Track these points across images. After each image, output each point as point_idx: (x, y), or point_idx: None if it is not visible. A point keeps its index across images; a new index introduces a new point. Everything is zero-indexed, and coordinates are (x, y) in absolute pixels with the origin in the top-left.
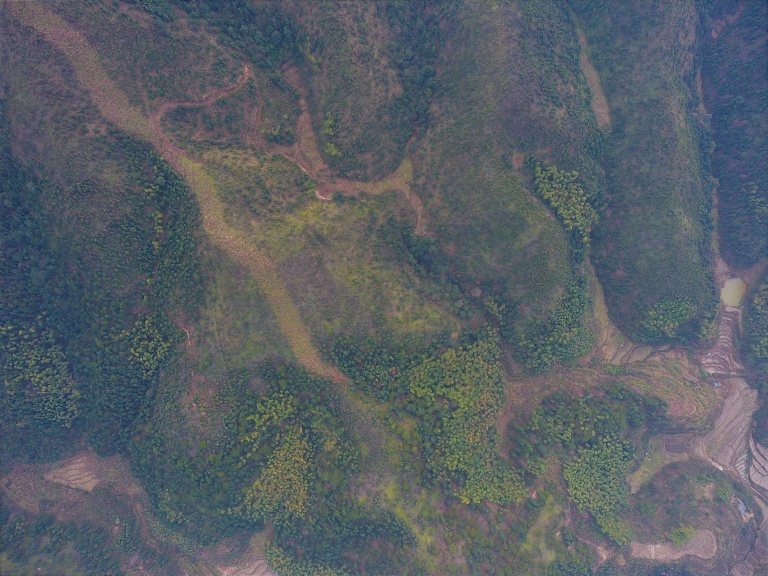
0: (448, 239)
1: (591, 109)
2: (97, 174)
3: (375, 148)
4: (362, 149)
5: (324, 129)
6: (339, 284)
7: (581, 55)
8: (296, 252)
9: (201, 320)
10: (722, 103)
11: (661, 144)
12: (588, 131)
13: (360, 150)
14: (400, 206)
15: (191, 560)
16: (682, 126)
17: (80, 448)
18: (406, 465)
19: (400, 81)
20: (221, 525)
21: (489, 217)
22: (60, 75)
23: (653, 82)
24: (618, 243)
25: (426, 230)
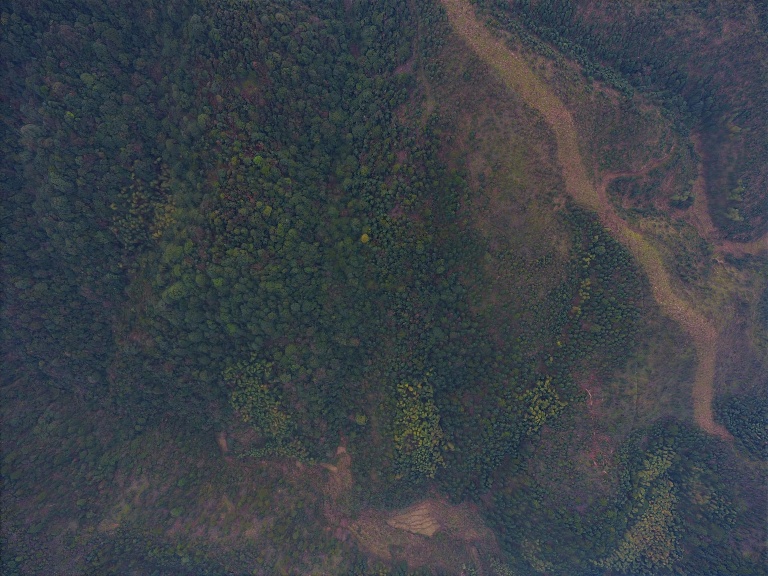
0: None
1: None
2: (556, 246)
3: (766, 212)
4: (759, 214)
5: (732, 195)
6: (751, 349)
7: None
8: (729, 320)
9: (613, 382)
10: None
11: None
12: None
13: (757, 214)
14: None
15: None
16: None
17: (429, 496)
18: None
19: None
20: (581, 574)
21: None
22: (548, 154)
23: None
24: None
25: None
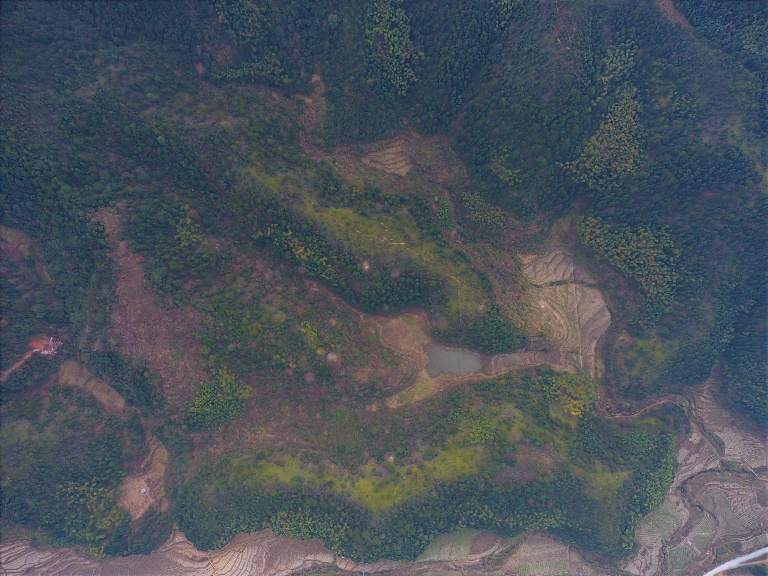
0: None
1: None
2: None
3: None
4: None
5: None
6: None
7: None
8: None
9: None
10: None
11: None
12: None
13: None
14: None
15: (497, 244)
16: None
17: (402, 127)
18: (753, 103)
19: None
20: (549, 188)
21: None
22: None
23: None
24: None
25: None
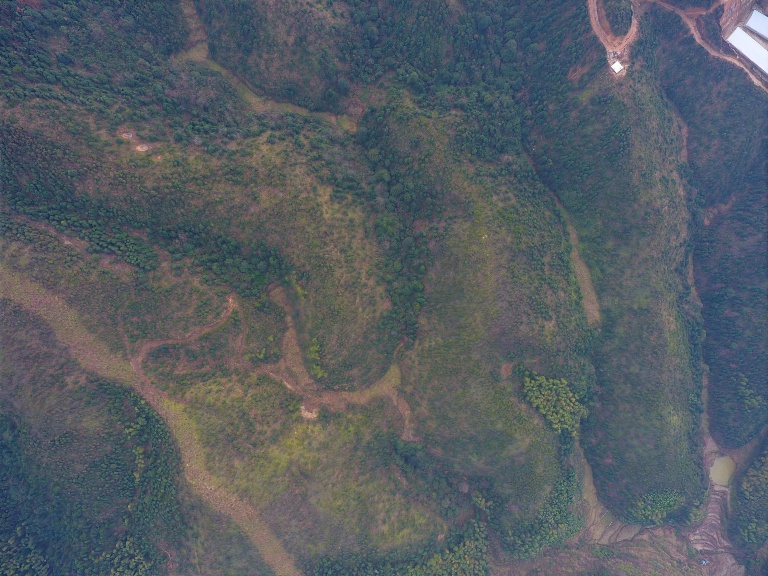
0: (435, 445)
1: (581, 310)
2: (76, 424)
3: (362, 364)
4: (349, 368)
5: (310, 353)
6: (323, 515)
7: (572, 251)
8: (279, 493)
9: (183, 548)
10: (713, 291)
11: (651, 350)
12: (578, 335)
13: (347, 369)
14: (387, 417)
15: None
16: (672, 328)
17: None
18: None
19: (388, 296)
20: None
21: (477, 433)
22: (38, 338)
23: (644, 290)
24: (607, 433)
25: (413, 435)
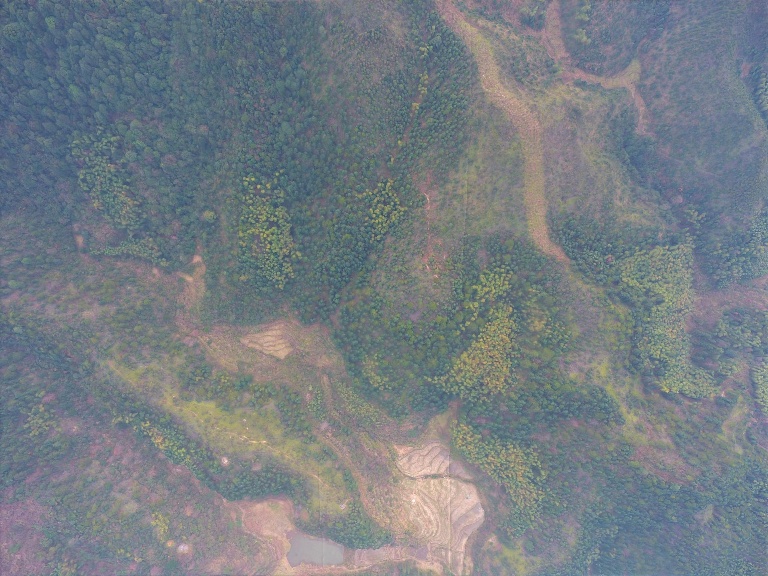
0: (667, 140)
1: None
2: (388, 24)
3: (617, 41)
4: (608, 39)
5: (579, 14)
6: (584, 161)
7: None
8: (557, 122)
9: (448, 184)
10: None
11: None
12: None
13: (606, 40)
14: (630, 102)
15: (372, 435)
16: None
17: (282, 314)
18: (621, 345)
19: None
20: (419, 396)
21: (717, 118)
22: None
23: None
24: None
25: (646, 130)
